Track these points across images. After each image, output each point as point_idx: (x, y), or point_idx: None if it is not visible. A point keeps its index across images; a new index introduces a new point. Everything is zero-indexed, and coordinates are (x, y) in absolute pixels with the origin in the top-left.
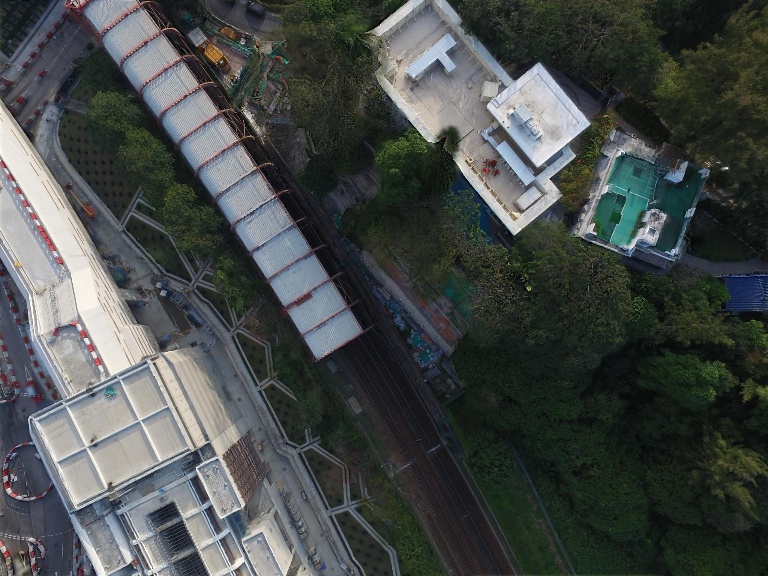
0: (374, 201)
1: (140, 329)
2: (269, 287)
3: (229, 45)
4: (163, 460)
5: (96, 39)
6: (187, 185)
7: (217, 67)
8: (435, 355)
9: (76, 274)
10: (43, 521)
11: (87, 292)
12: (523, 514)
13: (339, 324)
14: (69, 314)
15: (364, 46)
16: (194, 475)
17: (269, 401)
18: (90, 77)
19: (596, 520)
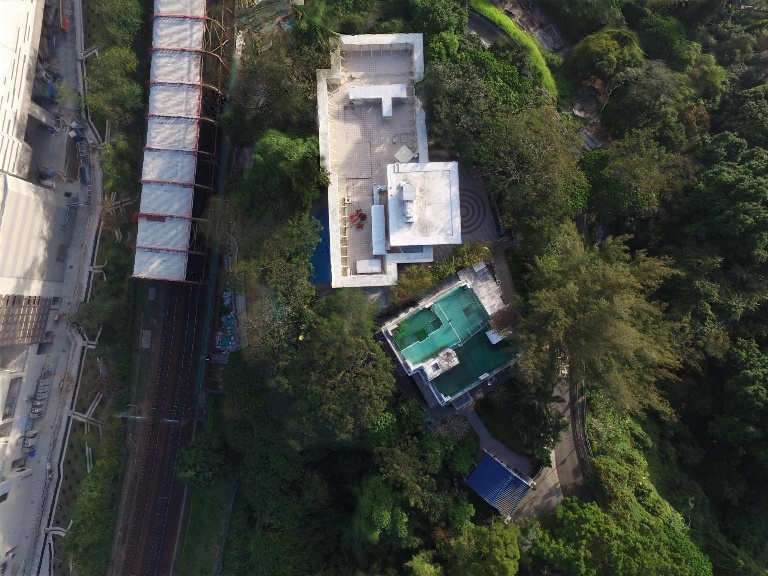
0: None
1: (17, 145)
2: None
3: None
4: None
5: None
6: (136, 56)
7: None
8: (235, 346)
9: None
10: None
11: None
12: (210, 531)
13: (169, 260)
14: None
15: (317, 40)
16: None
17: (92, 285)
18: None
19: None
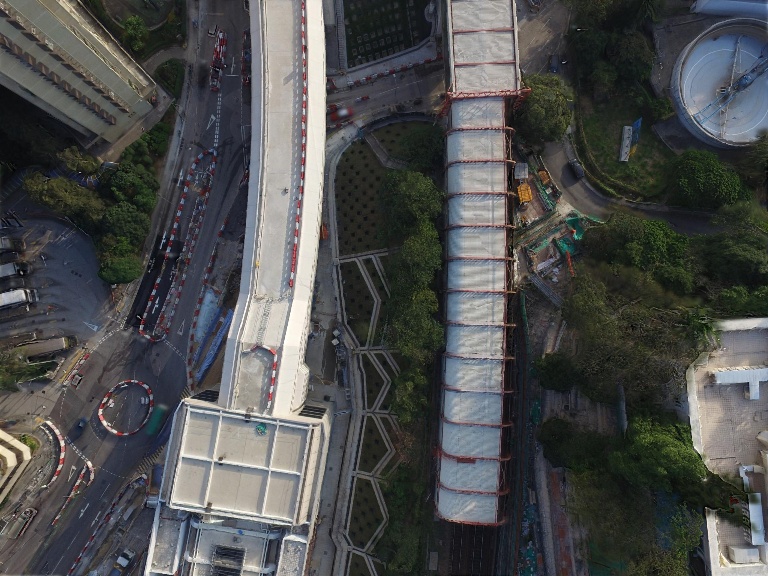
0: (597, 441)
1: None
2: (433, 413)
3: (538, 190)
4: (265, 516)
5: (426, 99)
6: None
7: (519, 205)
8: None
9: (296, 302)
10: (108, 455)
11: (296, 326)
12: None
13: (481, 502)
14: (273, 339)
15: (705, 343)
16: (275, 538)
17: (355, 490)
18: (414, 145)
19: None
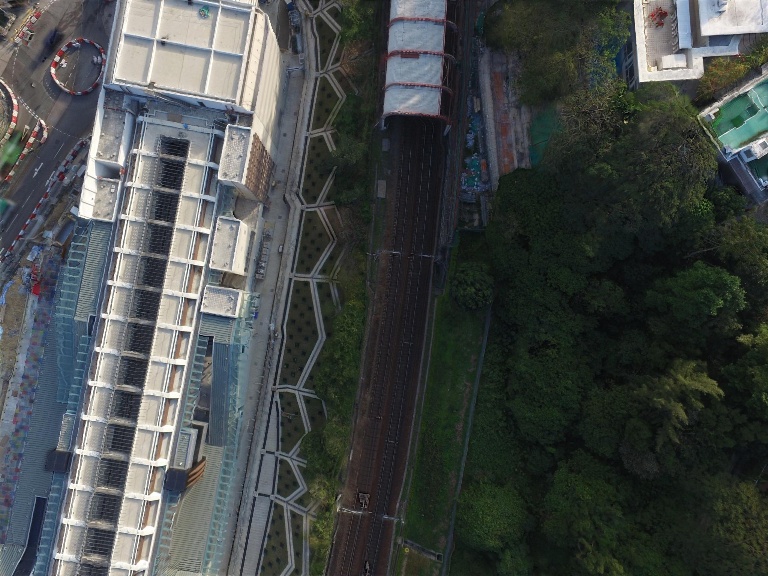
0: None
1: None
2: (382, 42)
3: None
4: (208, 94)
5: None
6: None
7: None
8: (480, 186)
9: None
10: (62, 115)
11: None
12: (457, 371)
13: (424, 95)
14: None
15: None
16: (220, 134)
17: (308, 150)
18: None
19: (521, 403)
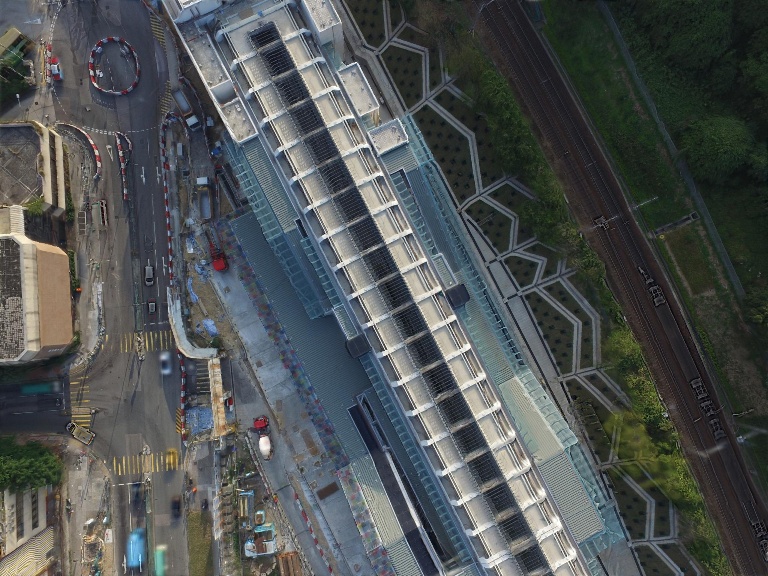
0: None
1: None
2: None
3: None
4: None
5: None
6: None
7: None
8: None
9: None
10: (129, 117)
11: None
12: (603, 68)
13: None
14: None
15: None
16: (291, 2)
17: (347, 4)
18: None
19: (679, 39)
